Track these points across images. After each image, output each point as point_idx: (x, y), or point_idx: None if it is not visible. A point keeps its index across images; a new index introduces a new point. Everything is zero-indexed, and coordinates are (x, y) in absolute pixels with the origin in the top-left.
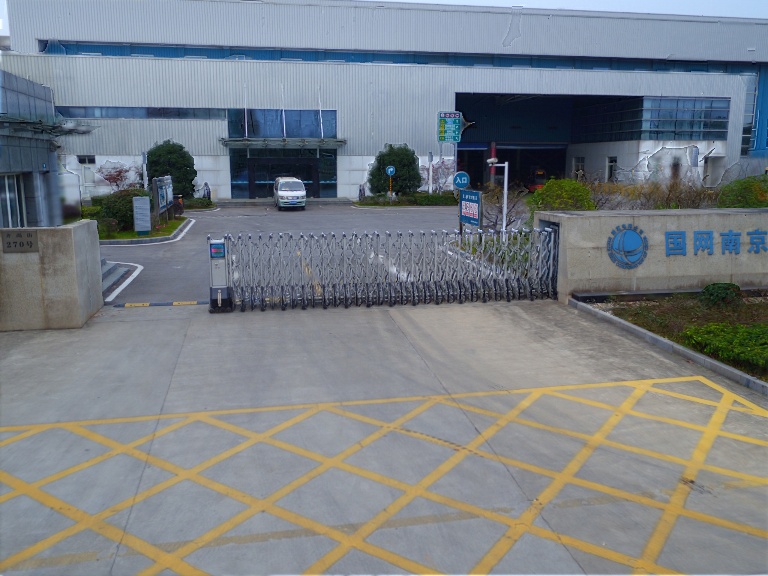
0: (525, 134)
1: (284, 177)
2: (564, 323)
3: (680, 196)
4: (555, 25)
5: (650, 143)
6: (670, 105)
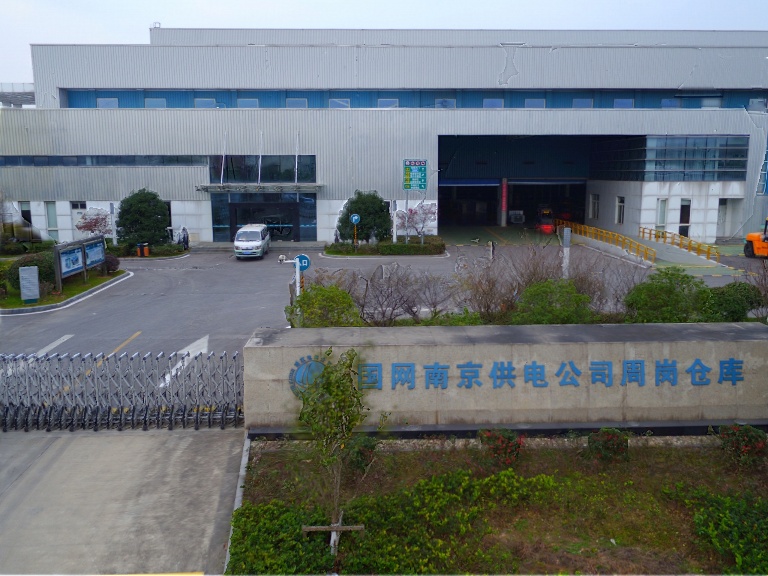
0: (539, 170)
1: (254, 224)
2: (196, 470)
3: (540, 281)
4: (569, 57)
5: (655, 184)
6: (678, 144)
